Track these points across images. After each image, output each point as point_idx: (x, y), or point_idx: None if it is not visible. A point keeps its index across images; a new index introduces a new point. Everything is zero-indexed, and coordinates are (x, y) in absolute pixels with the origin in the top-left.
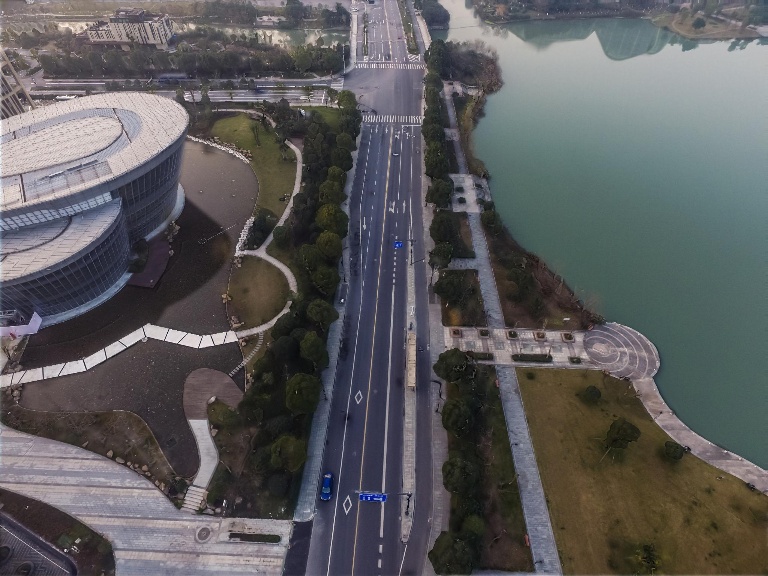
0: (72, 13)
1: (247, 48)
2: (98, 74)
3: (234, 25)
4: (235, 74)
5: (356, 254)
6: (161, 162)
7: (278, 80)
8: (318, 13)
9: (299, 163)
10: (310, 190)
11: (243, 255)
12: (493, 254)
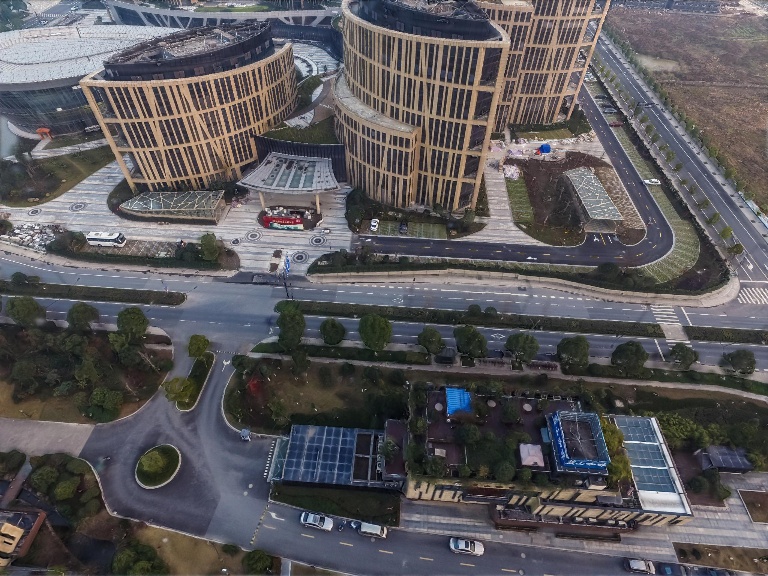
0: None
1: None
2: None
3: None
4: None
5: None
6: None
7: None
8: None
9: None
10: None
11: None
12: None
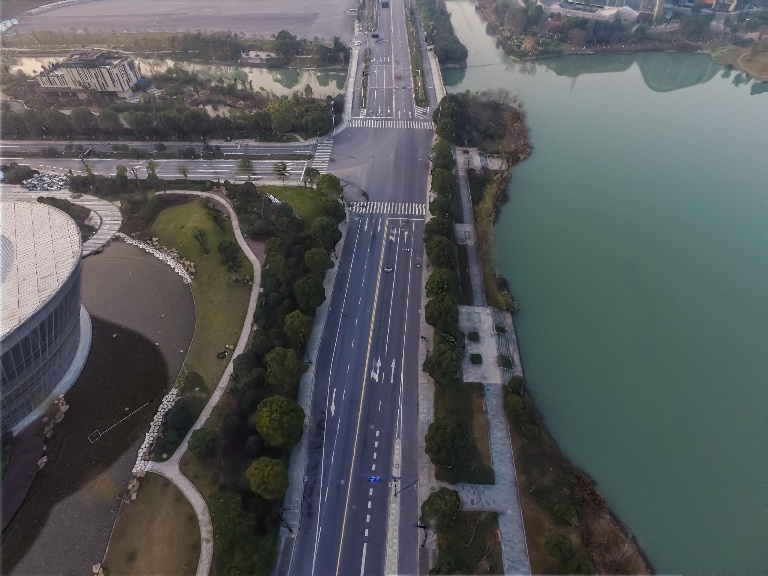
0: (38, 47)
1: (224, 95)
2: (37, 135)
3: (216, 62)
4: (200, 136)
5: (314, 468)
6: (20, 340)
7: (252, 144)
8: (313, 48)
9: (255, 286)
10: (258, 348)
11: (144, 473)
12: (522, 475)
